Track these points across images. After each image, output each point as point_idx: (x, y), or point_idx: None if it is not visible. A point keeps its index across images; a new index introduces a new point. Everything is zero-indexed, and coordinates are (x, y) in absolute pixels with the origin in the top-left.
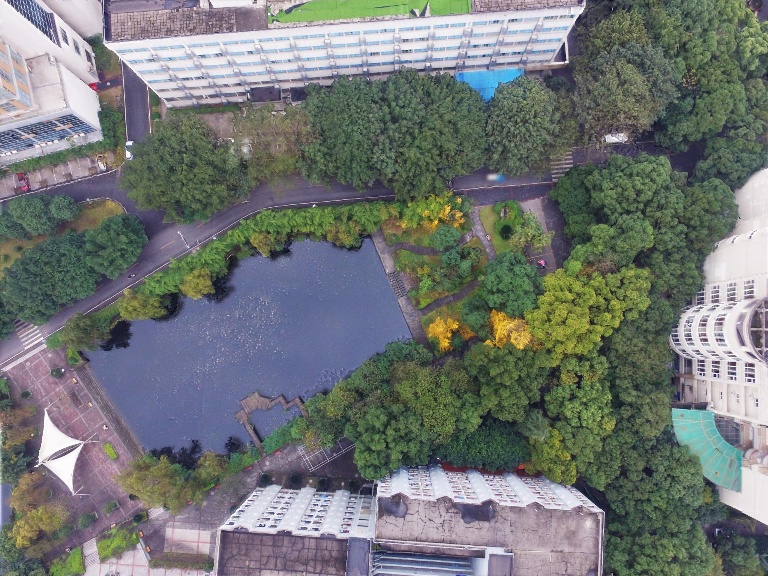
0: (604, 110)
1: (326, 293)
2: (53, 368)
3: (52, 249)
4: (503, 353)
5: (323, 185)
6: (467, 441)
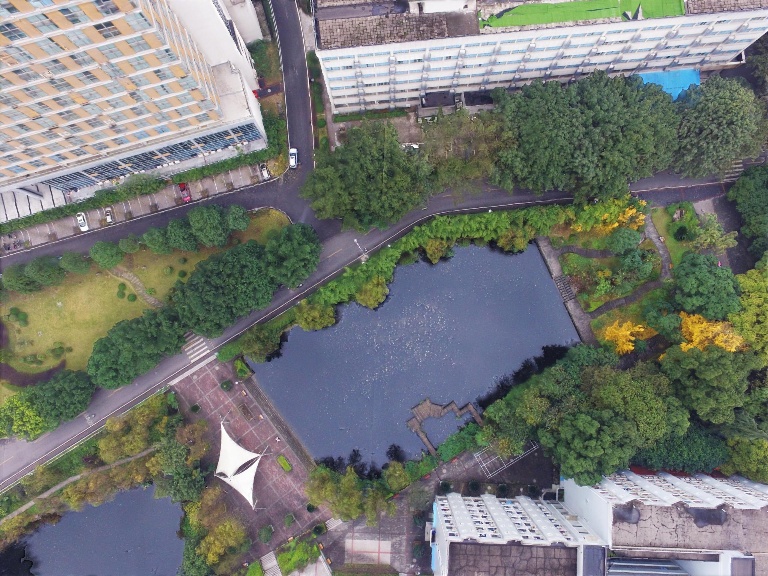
0: None
1: (493, 298)
2: (221, 381)
3: (232, 261)
4: (717, 356)
5: None
6: (666, 444)
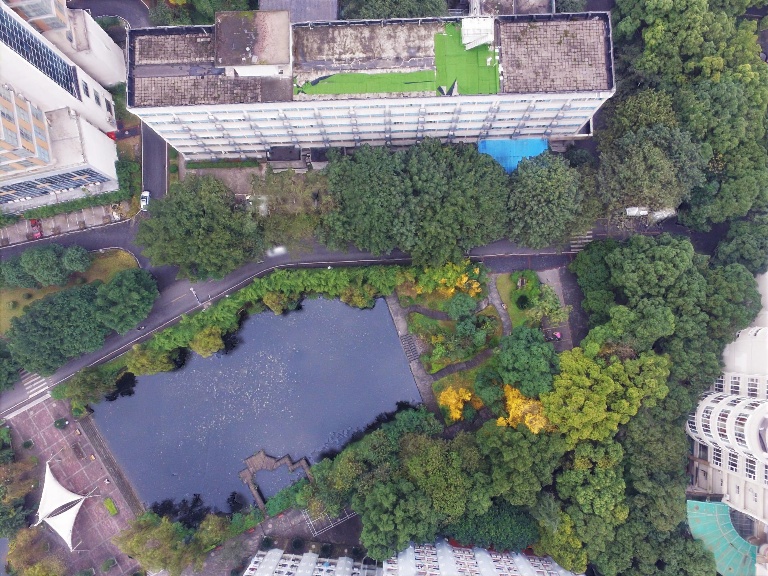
0: (629, 194)
1: (337, 353)
2: (57, 418)
3: (62, 302)
4: (517, 437)
5: (340, 249)
6: (476, 520)
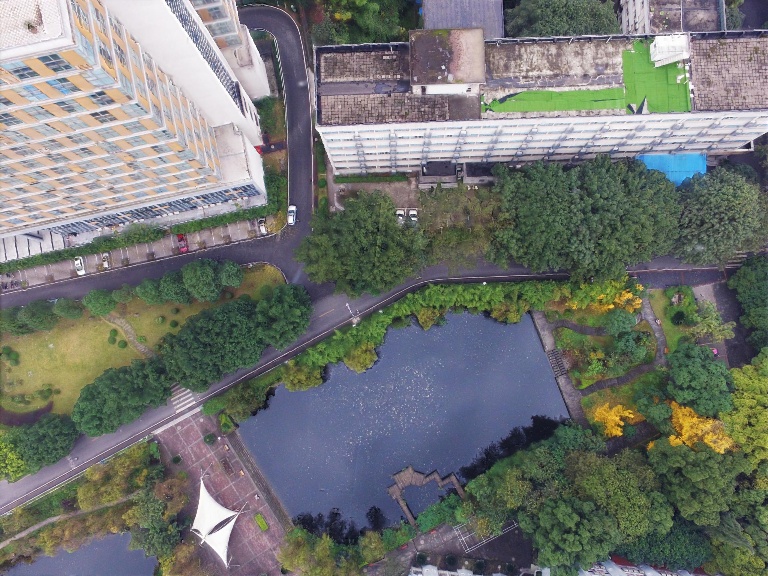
0: None
1: (483, 368)
2: (205, 433)
3: (222, 319)
4: (705, 457)
5: None
6: (648, 539)
